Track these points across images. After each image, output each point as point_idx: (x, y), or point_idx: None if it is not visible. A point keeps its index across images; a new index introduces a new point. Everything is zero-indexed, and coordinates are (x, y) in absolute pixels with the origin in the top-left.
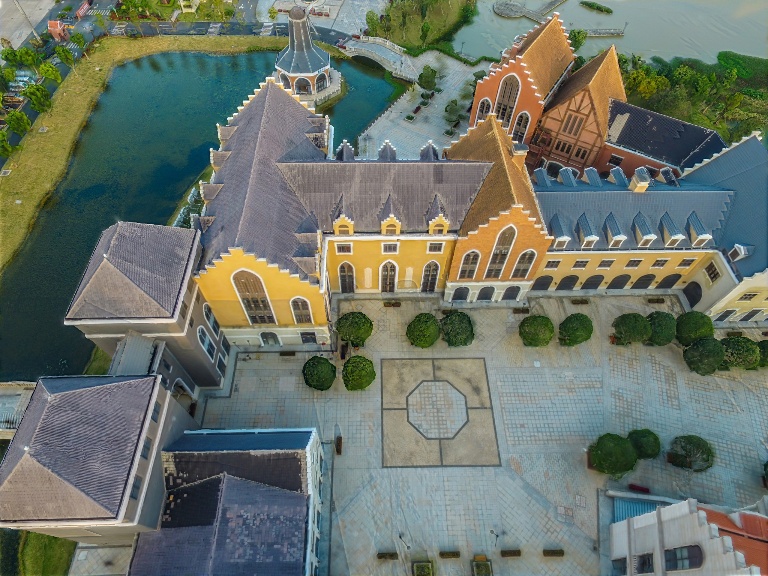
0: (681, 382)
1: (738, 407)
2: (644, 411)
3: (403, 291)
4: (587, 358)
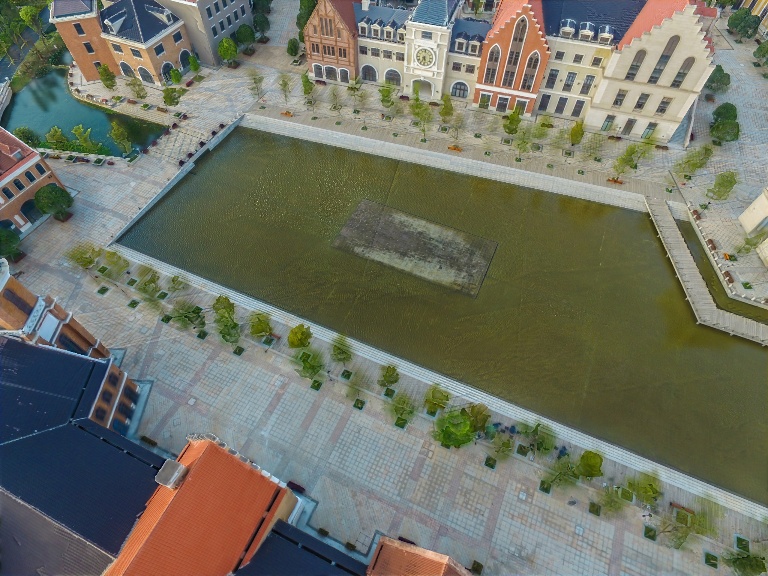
0: (766, 112)
1: (761, 129)
2: (734, 94)
3: (761, 28)
4: (759, 82)
